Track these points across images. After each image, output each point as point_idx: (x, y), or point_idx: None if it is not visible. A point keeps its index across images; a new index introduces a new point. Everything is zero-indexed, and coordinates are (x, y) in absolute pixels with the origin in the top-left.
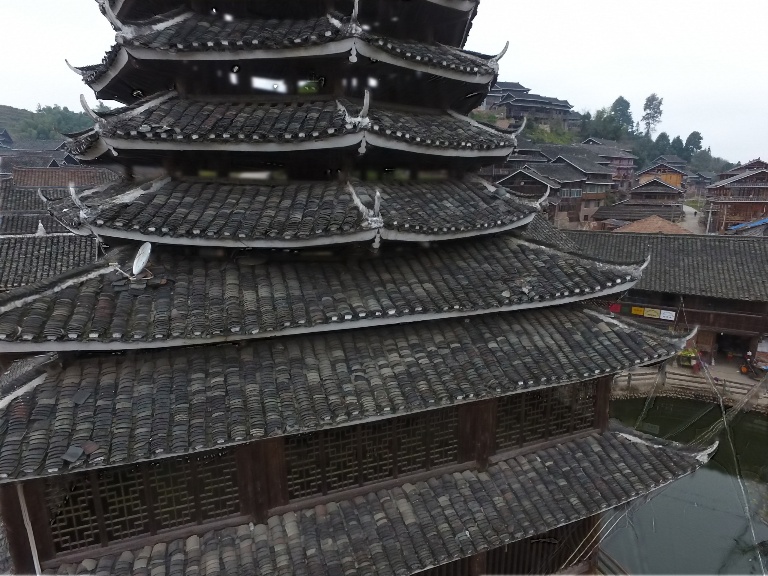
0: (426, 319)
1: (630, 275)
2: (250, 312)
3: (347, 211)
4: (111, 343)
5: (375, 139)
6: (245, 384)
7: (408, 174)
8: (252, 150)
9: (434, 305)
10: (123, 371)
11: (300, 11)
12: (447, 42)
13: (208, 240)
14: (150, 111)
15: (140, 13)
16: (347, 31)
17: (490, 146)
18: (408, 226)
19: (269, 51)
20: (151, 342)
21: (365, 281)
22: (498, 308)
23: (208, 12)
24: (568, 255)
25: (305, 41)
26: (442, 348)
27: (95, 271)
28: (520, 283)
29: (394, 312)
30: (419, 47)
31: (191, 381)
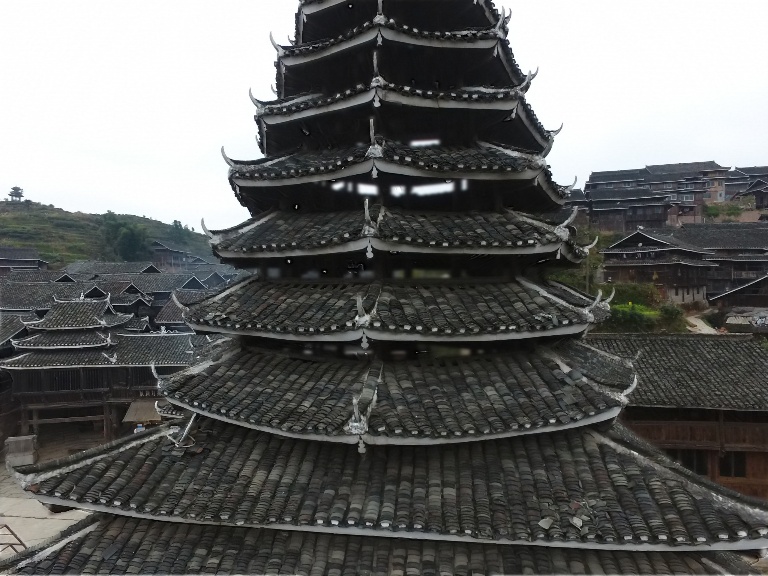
0: (431, 538)
1: (766, 528)
2: (248, 498)
3: (349, 405)
4: (130, 511)
5: (377, 335)
6: (235, 572)
7: (450, 353)
8: (279, 338)
9: (439, 524)
10: (150, 531)
11: (355, 203)
12: (527, 203)
13: (232, 419)
14: (229, 296)
15: (257, 210)
16: (361, 233)
17: (545, 327)
18: (401, 431)
19: (304, 250)
20: (158, 516)
21: (380, 474)
22: (530, 542)
23: (291, 209)
24: (670, 472)
25: (330, 242)
26: (460, 575)
27: (157, 434)
28: (576, 508)
29: (388, 525)
30: (475, 220)
31: (194, 556)
